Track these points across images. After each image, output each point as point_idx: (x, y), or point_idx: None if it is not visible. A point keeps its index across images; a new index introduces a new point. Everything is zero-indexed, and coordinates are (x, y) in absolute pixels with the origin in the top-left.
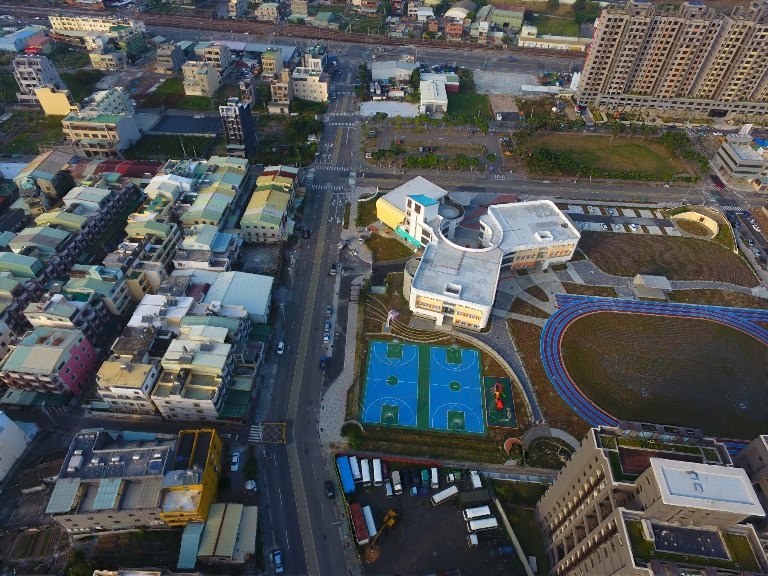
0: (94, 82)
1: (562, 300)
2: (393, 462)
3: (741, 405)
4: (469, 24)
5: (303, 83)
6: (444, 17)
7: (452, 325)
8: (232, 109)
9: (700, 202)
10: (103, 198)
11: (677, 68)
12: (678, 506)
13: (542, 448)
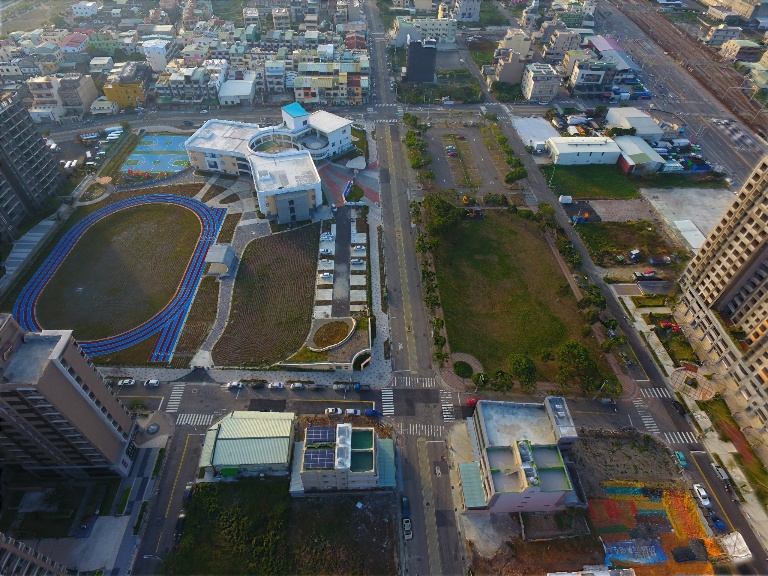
0: (494, 25)
1: (219, 210)
2: None
3: (81, 288)
4: None
5: None
6: None
7: None
8: None
9: (398, 364)
10: (309, 38)
11: None
12: None
13: (99, 189)
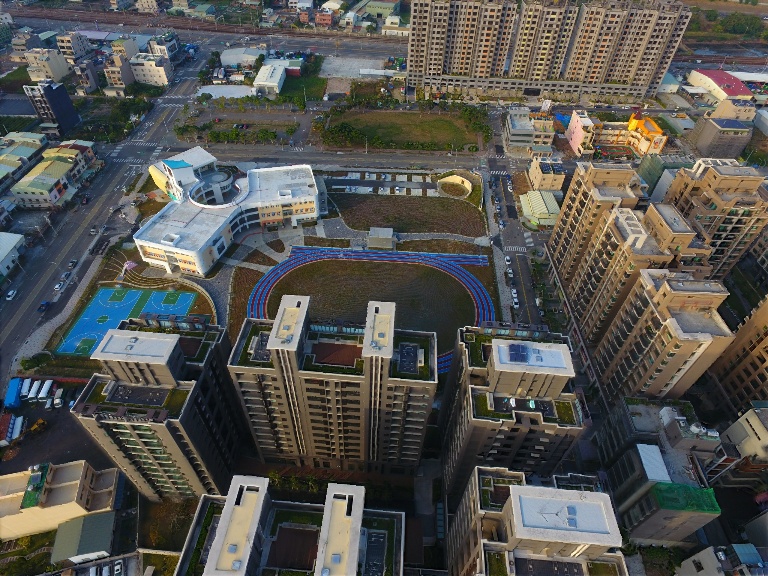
0: None
1: (296, 251)
2: (66, 383)
3: None
4: (340, 15)
5: (141, 68)
6: (321, 8)
7: (182, 273)
8: (36, 88)
9: (473, 168)
10: None
11: (485, 50)
12: None
13: None
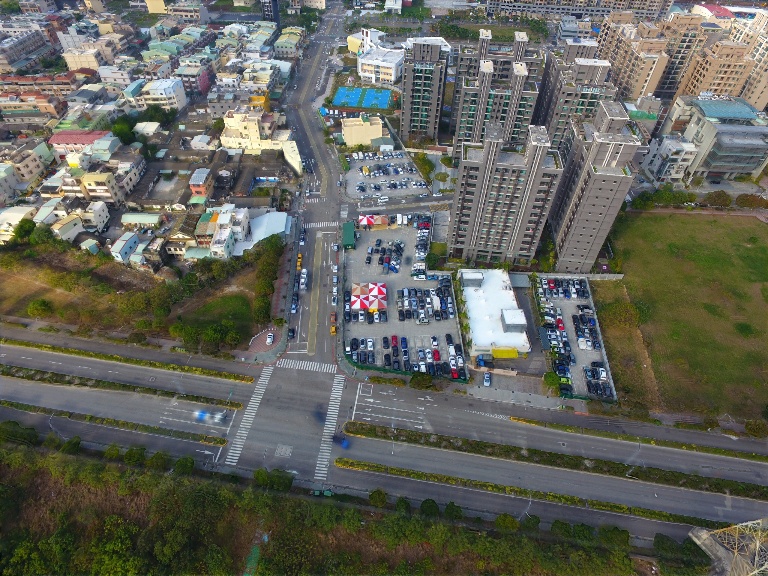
0: None
1: None
2: None
3: None
4: None
5: None
6: None
7: None
8: None
9: None
10: (202, 32)
11: None
12: (419, 48)
13: None
